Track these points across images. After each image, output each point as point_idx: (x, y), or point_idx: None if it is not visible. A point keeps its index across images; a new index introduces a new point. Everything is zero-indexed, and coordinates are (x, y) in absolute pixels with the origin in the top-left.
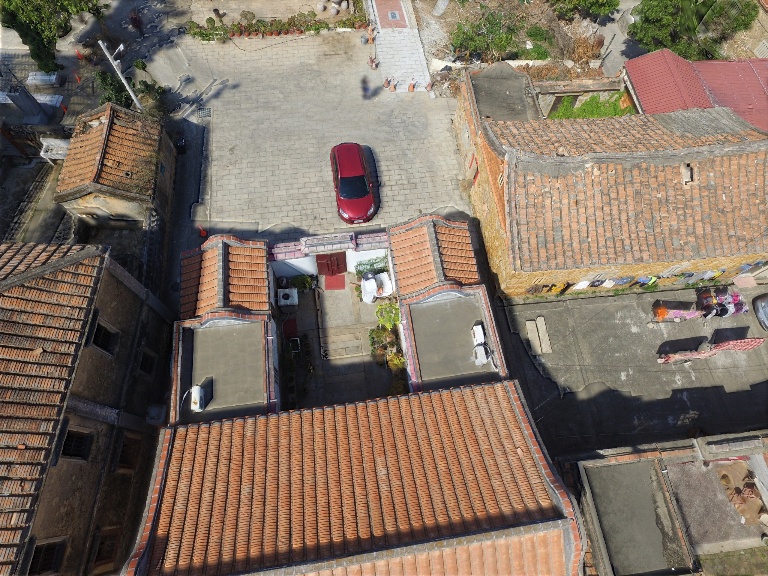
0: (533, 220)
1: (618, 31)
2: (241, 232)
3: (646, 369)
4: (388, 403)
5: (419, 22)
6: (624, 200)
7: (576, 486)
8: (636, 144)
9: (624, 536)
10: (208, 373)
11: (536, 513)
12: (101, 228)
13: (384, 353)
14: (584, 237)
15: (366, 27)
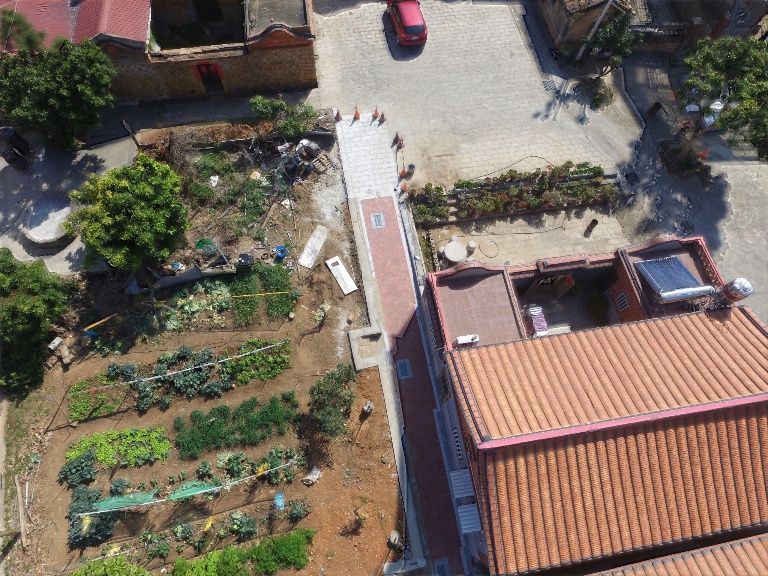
0: None
1: None
2: None
3: None
4: None
5: (346, 214)
6: None
7: None
8: None
9: None
10: None
11: None
12: None
13: None
14: None
15: None
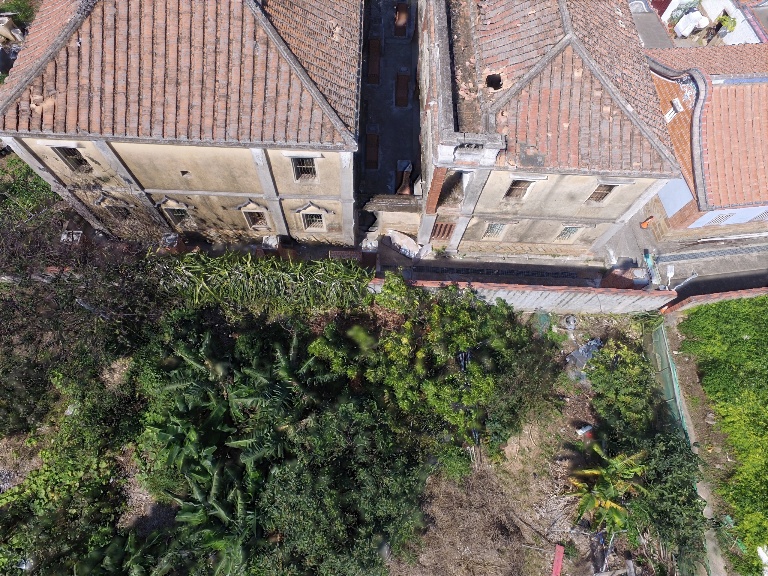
0: None
1: None
2: None
3: None
4: None
5: None
6: None
7: None
8: None
9: None
10: None
11: None
12: None
13: None
14: None
15: None
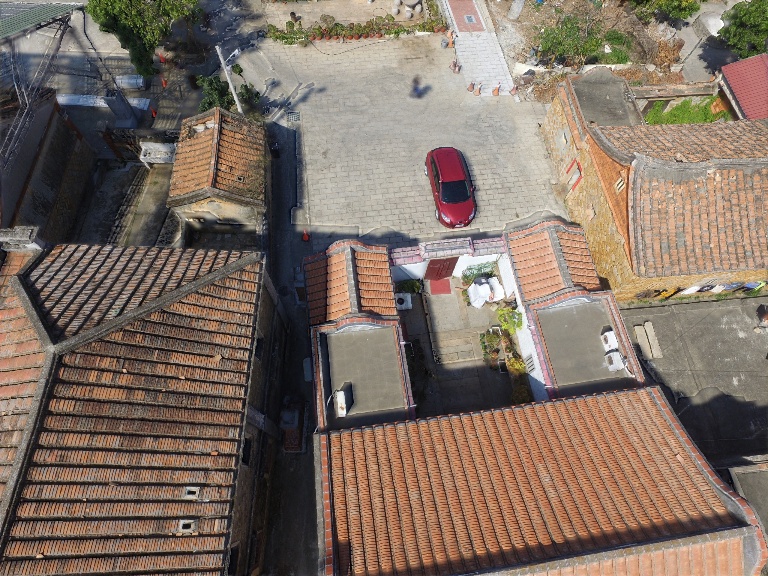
0: (657, 226)
1: (693, 35)
2: (342, 236)
3: (757, 374)
4: (534, 409)
5: (495, 26)
6: (745, 206)
7: None
8: (751, 150)
9: None
10: (346, 378)
11: (714, 520)
12: (203, 232)
13: (497, 358)
14: (706, 243)
15: (445, 31)
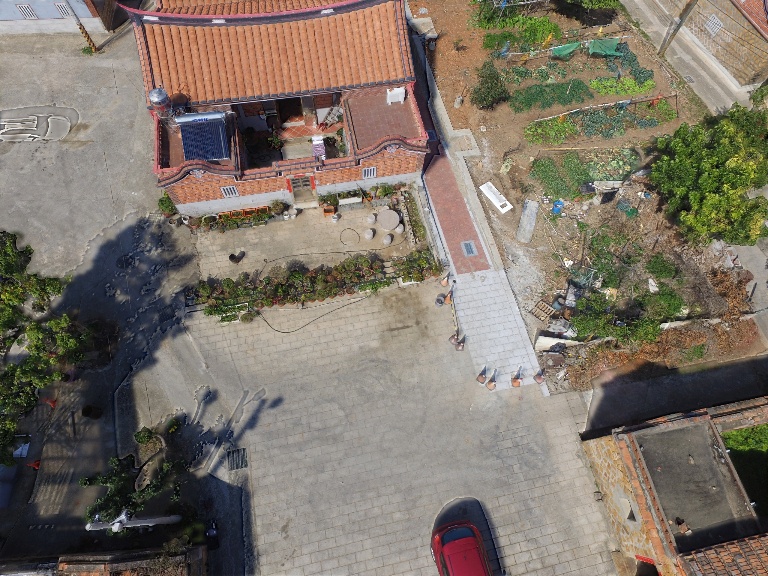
0: None
1: (755, 247)
2: None
3: None
4: None
5: (503, 256)
6: None
7: None
8: None
9: None
10: None
11: None
12: None
13: None
14: None
15: (438, 276)
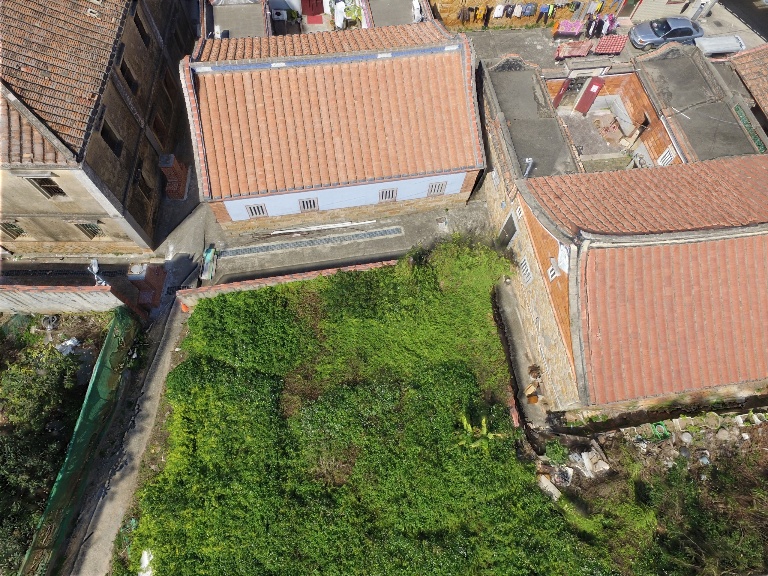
0: None
1: None
2: None
3: None
4: (352, 31)
5: None
6: None
7: (480, 79)
8: None
9: (512, 104)
10: (225, 28)
11: None
12: None
13: None
14: None
15: None
